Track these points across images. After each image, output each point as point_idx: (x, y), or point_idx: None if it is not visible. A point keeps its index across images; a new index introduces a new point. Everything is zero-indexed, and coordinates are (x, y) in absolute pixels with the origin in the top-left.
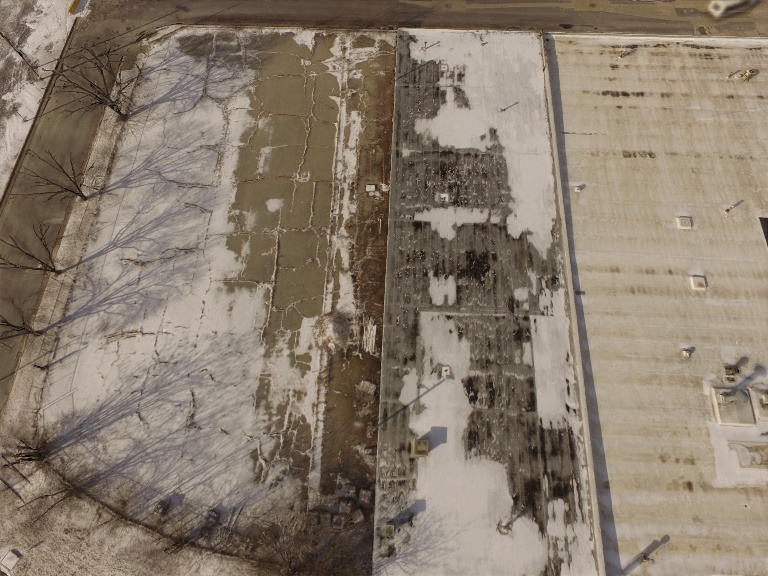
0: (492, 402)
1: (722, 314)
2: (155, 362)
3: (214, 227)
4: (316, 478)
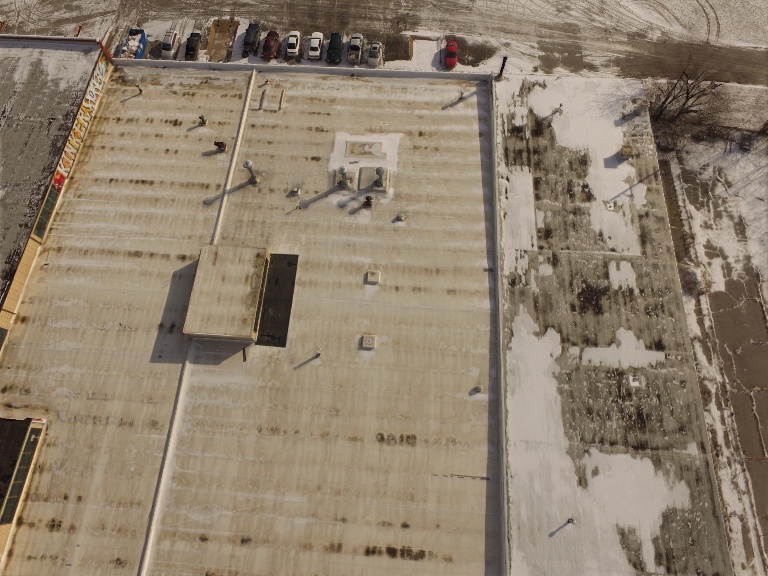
0: (569, 184)
1: (359, 249)
2: None
3: None
4: (674, 170)
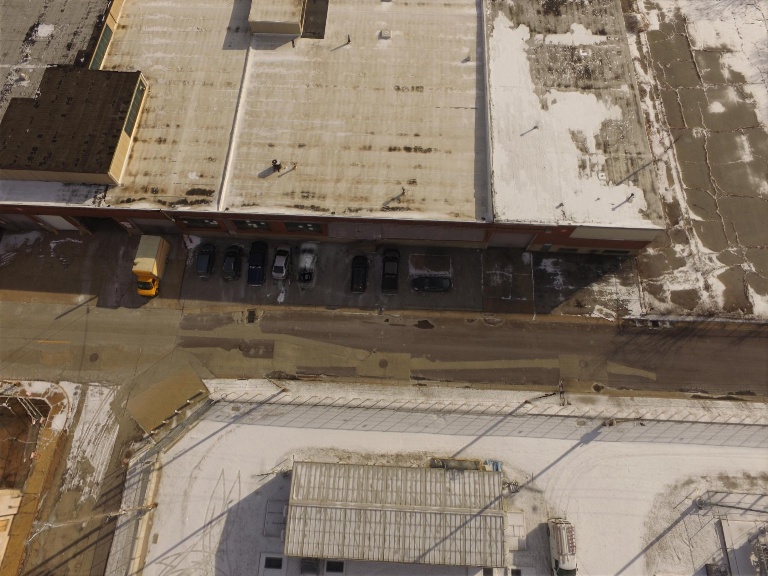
0: None
1: None
2: (757, 4)
3: (762, 89)
4: None
